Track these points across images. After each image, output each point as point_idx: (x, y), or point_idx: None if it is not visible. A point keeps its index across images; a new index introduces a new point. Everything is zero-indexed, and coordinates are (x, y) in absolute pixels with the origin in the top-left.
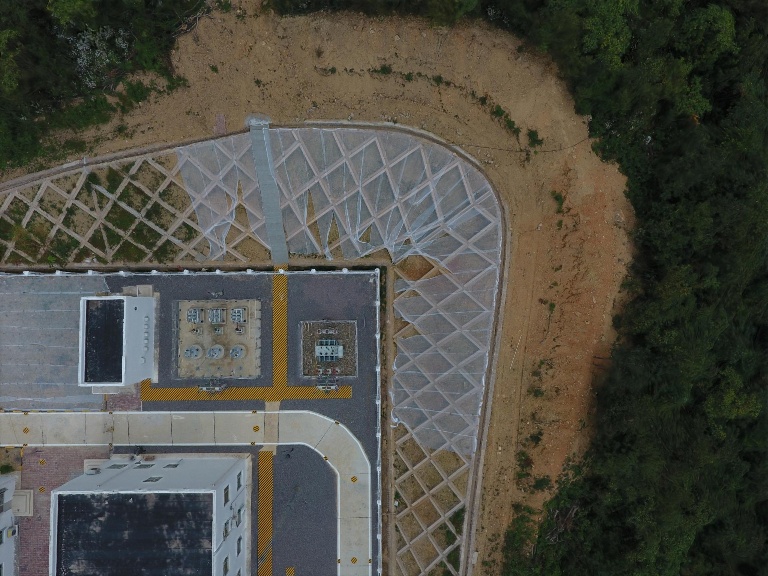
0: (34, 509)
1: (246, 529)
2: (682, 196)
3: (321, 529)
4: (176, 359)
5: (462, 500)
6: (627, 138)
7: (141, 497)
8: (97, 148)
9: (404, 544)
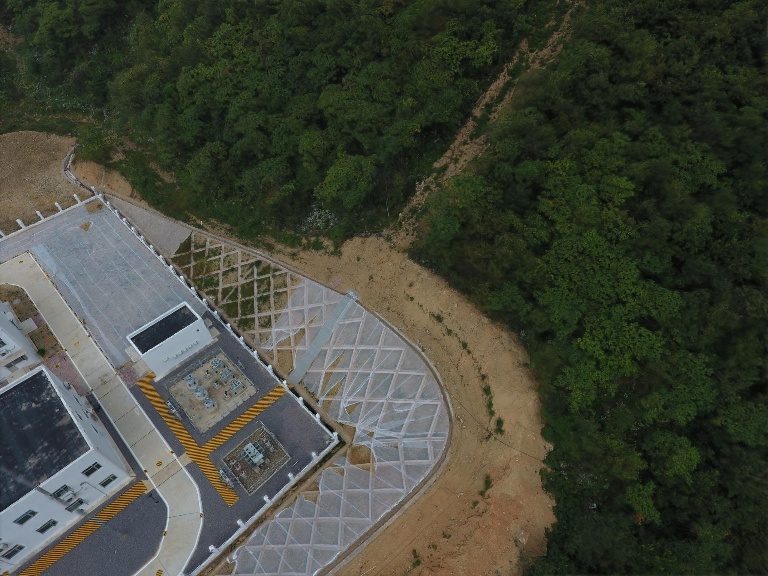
0: None
1: (65, 526)
2: (586, 565)
3: None
4: (180, 379)
5: None
6: (574, 488)
7: (63, 414)
8: (275, 254)
9: None
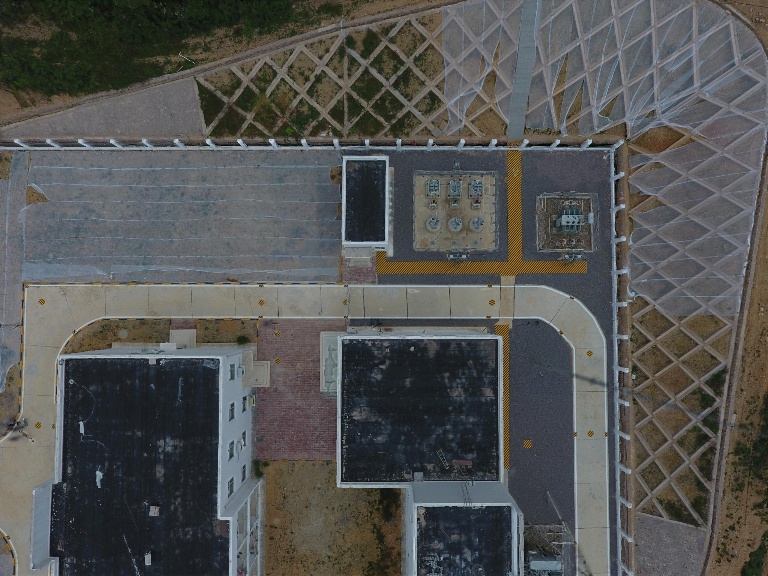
0: (270, 380)
1: None
2: None
3: (557, 402)
4: (411, 233)
5: (723, 361)
6: None
7: (422, 345)
8: (355, 11)
9: (644, 416)
